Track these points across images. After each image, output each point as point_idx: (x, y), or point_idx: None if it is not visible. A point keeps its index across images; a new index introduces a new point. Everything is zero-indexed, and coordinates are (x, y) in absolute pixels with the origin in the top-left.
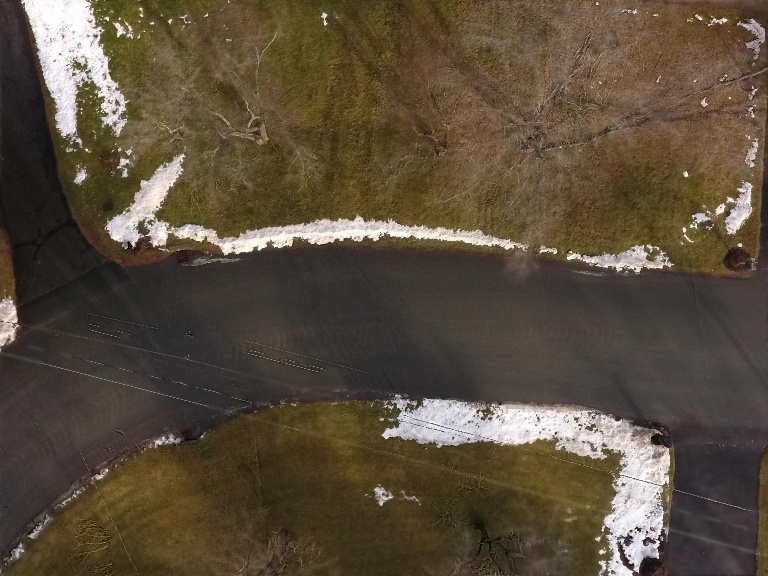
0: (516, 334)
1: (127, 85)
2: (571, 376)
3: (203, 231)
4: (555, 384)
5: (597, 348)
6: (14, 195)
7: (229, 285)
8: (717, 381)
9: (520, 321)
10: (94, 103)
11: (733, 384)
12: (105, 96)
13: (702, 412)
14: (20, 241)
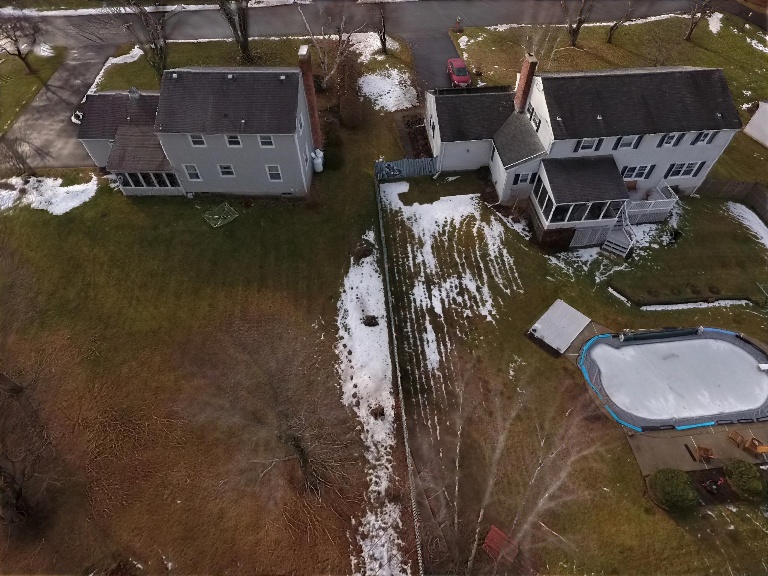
0: (540, 8)
1: (760, 52)
2: (511, 3)
3: (685, 16)
4: (516, 1)
5: (505, 8)
6: (767, 21)
7: (661, 8)
8: (451, 7)
9: (541, 11)
10: (767, 46)
11: (444, 7)
12: (765, 48)
13: (453, 2)
14: (750, 11)
